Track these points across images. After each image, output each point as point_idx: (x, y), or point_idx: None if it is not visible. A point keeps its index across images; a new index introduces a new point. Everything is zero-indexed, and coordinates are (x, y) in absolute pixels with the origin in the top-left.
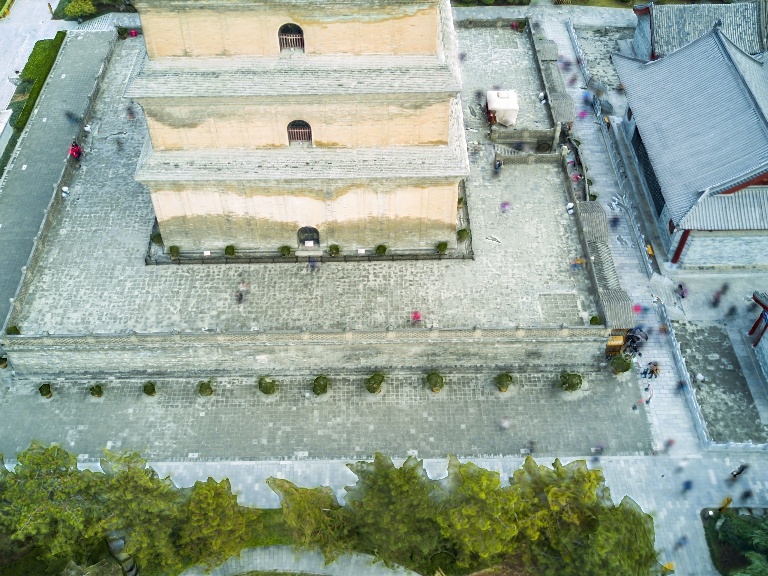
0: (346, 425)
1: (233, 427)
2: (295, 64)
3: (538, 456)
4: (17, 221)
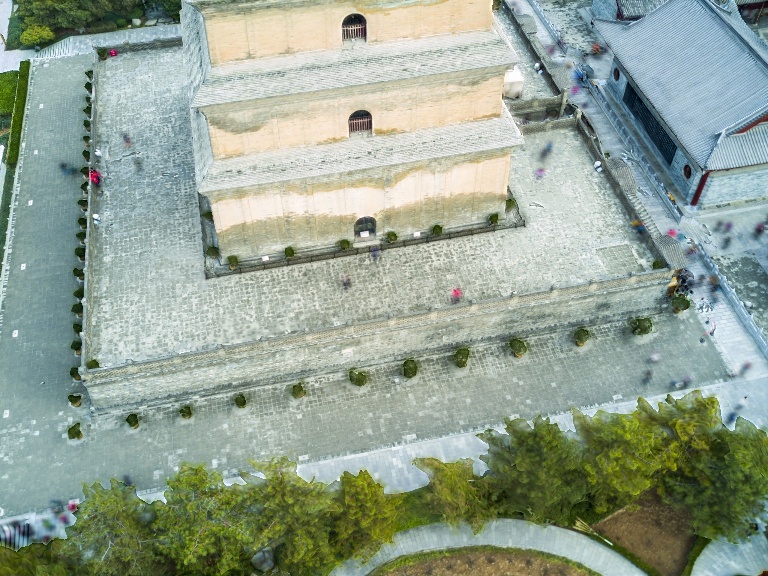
0: (444, 403)
1: (334, 424)
2: (358, 54)
3: (630, 400)
4: (41, 258)
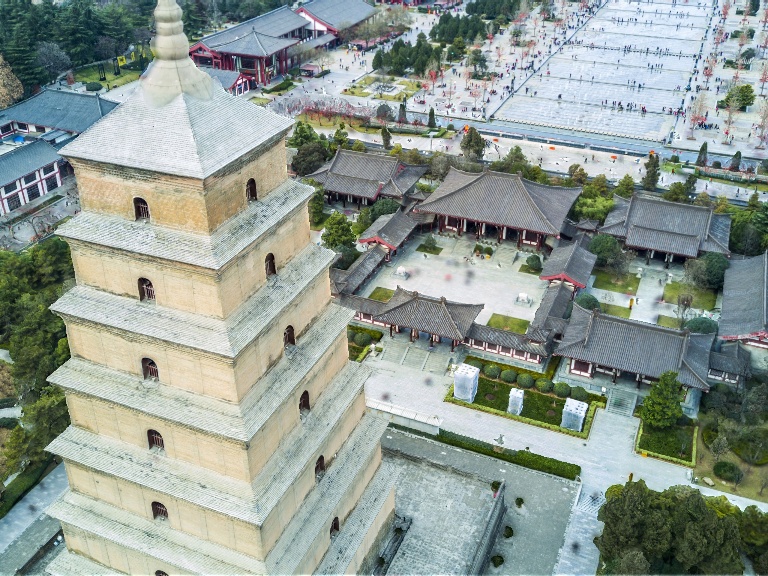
0: (39, 542)
1: None
2: None
3: None
4: None
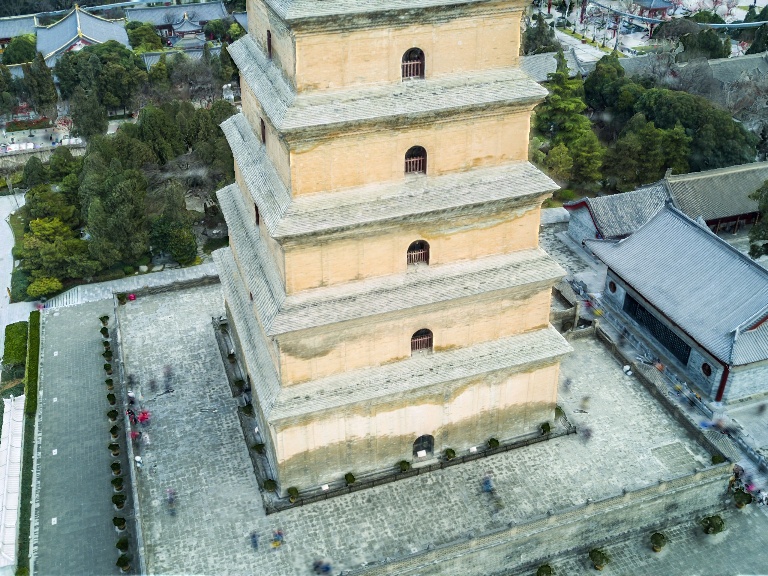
0: None
1: None
2: (421, 277)
3: None
4: (73, 510)
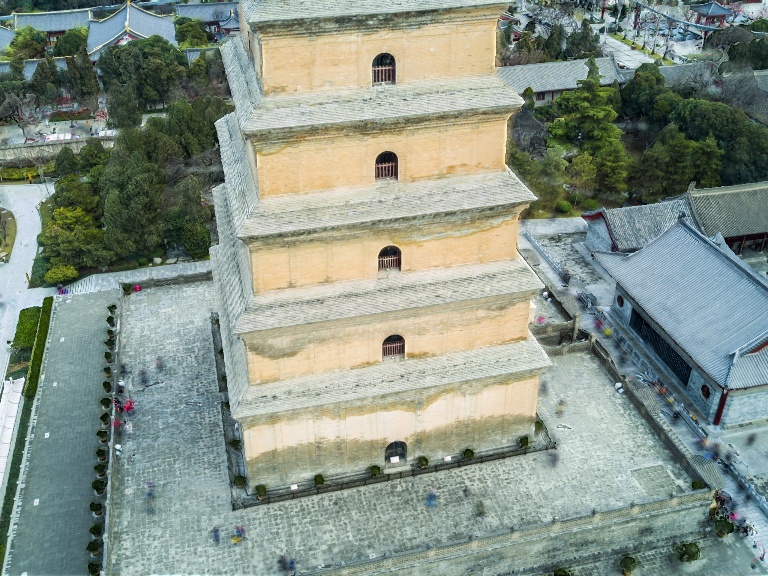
0: None
1: None
2: (392, 282)
3: None
4: (56, 492)
